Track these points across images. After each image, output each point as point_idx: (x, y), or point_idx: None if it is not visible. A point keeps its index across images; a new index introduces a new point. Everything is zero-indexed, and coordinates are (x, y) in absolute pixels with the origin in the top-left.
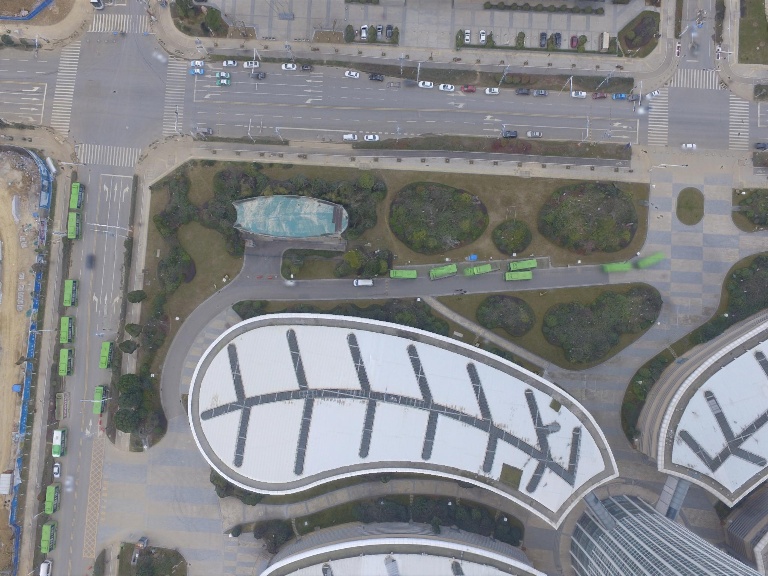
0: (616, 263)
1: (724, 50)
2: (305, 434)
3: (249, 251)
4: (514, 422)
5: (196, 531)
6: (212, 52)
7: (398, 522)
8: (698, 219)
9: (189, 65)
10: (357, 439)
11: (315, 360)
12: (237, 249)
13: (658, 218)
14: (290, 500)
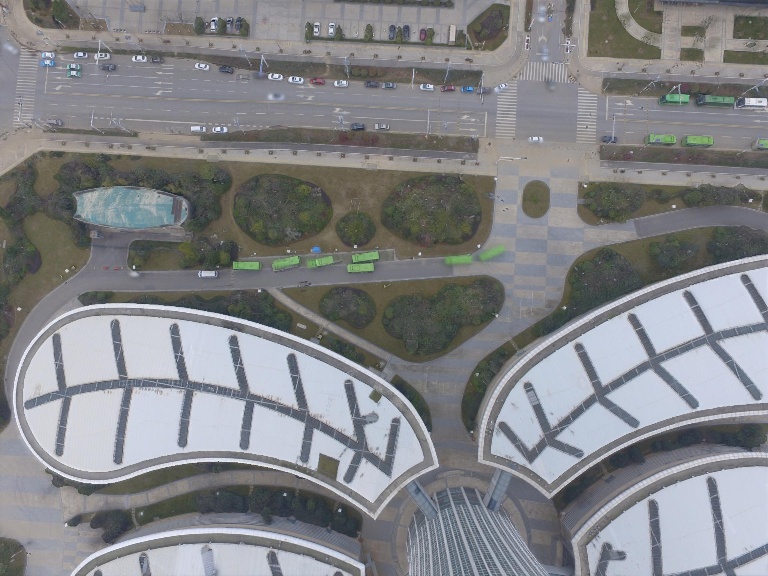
0: (461, 256)
1: (574, 43)
2: (123, 423)
3: (96, 242)
4: (331, 412)
5: (37, 521)
6: (63, 44)
7: (236, 513)
8: (543, 212)
9: (40, 57)
10: (175, 429)
11: (136, 350)
12: (82, 240)
13: (504, 211)
14: (131, 490)
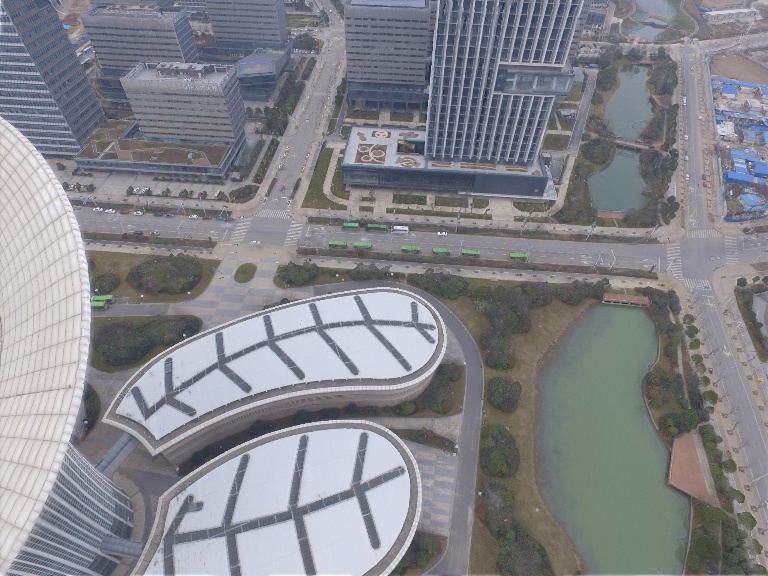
0: (177, 303)
1: (294, 202)
2: None
3: None
4: None
5: None
6: None
7: None
8: (248, 280)
9: None
10: None
11: None
12: None
13: (220, 278)
14: None
